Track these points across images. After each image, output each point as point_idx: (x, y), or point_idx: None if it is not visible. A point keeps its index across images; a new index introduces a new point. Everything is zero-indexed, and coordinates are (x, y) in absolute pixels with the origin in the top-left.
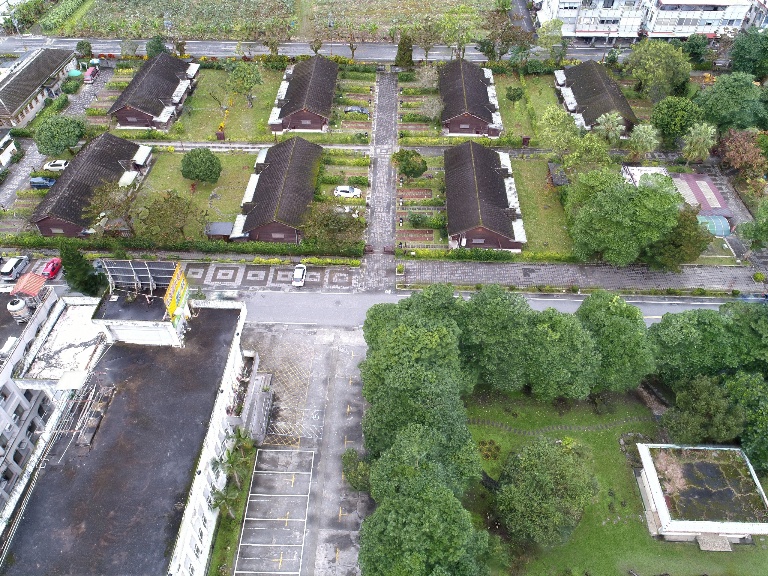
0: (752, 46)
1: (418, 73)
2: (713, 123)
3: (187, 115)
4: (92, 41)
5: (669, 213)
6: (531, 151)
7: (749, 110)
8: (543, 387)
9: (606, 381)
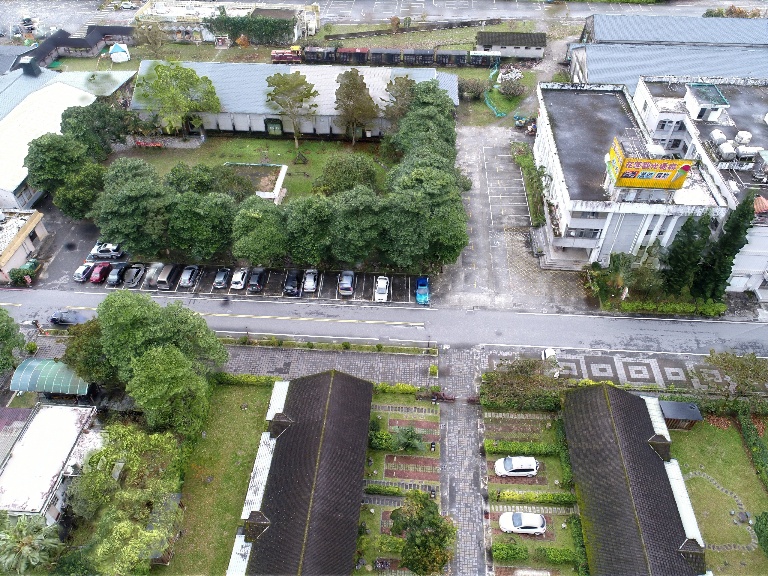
0: None
1: None
2: None
3: None
4: None
5: None
6: None
7: None
8: None
9: None
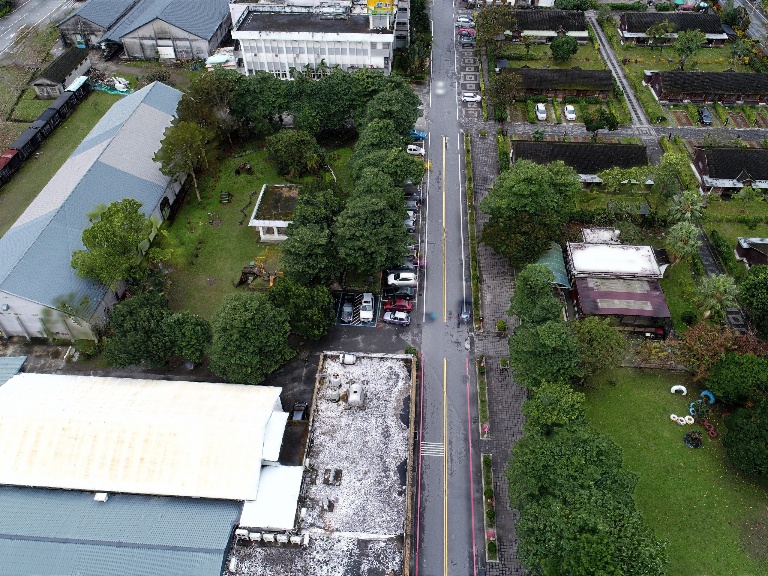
0: None
1: None
2: None
3: None
4: None
5: None
6: None
7: None
8: None
9: None
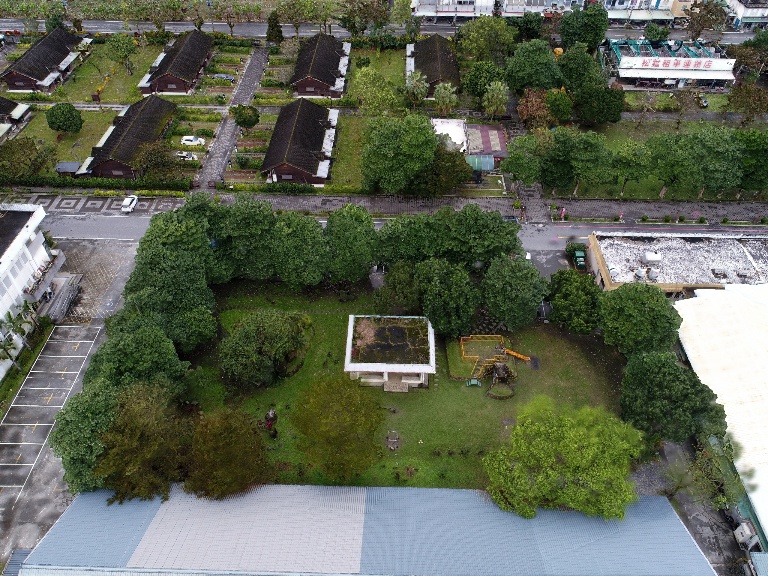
0: (575, 21)
1: (283, 46)
2: (516, 84)
3: (72, 81)
4: (4, 21)
5: (427, 147)
6: (366, 110)
7: (546, 72)
8: (287, 275)
9: (334, 269)
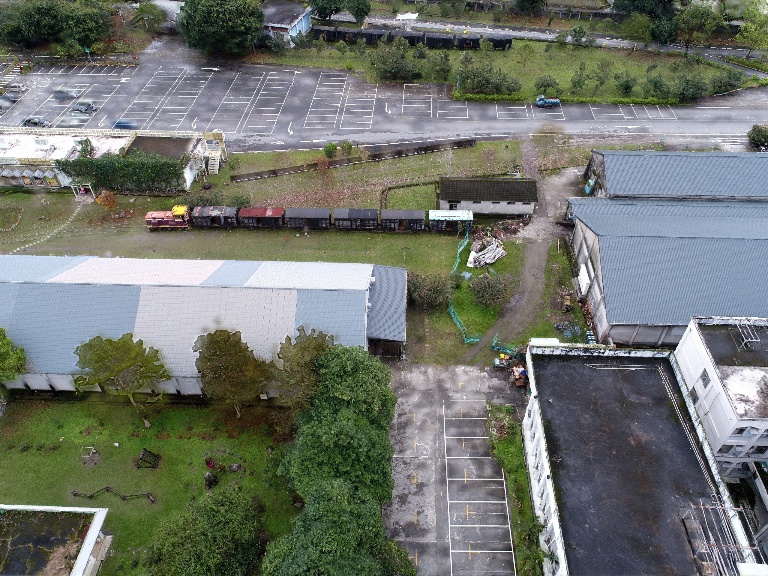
0: None
1: None
2: None
3: None
4: None
5: None
6: None
7: None
8: None
9: None
